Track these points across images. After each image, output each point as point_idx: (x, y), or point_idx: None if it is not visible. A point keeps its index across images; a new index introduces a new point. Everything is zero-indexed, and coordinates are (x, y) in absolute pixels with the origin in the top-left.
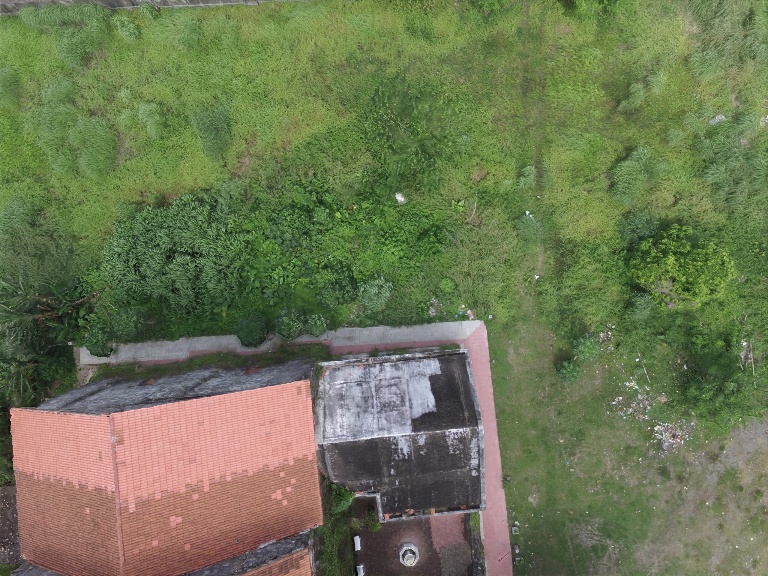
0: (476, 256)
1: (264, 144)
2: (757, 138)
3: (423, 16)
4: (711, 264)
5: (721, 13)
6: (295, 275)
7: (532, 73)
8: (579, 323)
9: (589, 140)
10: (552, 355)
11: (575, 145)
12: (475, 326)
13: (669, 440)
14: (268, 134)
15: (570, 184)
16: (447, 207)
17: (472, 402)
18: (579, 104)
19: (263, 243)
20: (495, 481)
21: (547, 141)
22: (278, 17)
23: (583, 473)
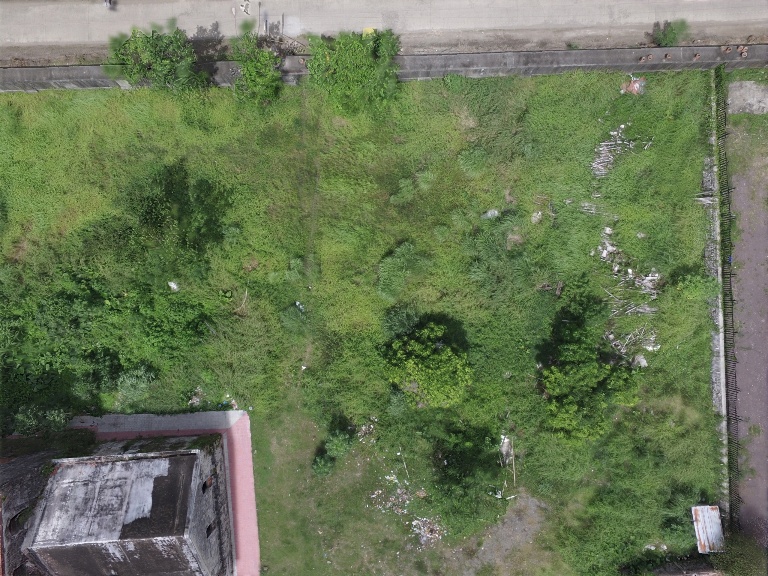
0: (239, 347)
1: (38, 230)
2: (528, 234)
3: (200, 106)
4: (440, 373)
5: (493, 109)
6: (63, 361)
7: (307, 164)
8: (340, 416)
9: (360, 233)
10: (314, 447)
11: (345, 238)
12: (238, 416)
13: (427, 535)
14: (42, 221)
15: (340, 276)
16: (216, 297)
17: (186, 508)
18: (352, 196)
19: (30, 330)
20: (253, 571)
21: (320, 232)
22: (58, 104)
23: (340, 566)
